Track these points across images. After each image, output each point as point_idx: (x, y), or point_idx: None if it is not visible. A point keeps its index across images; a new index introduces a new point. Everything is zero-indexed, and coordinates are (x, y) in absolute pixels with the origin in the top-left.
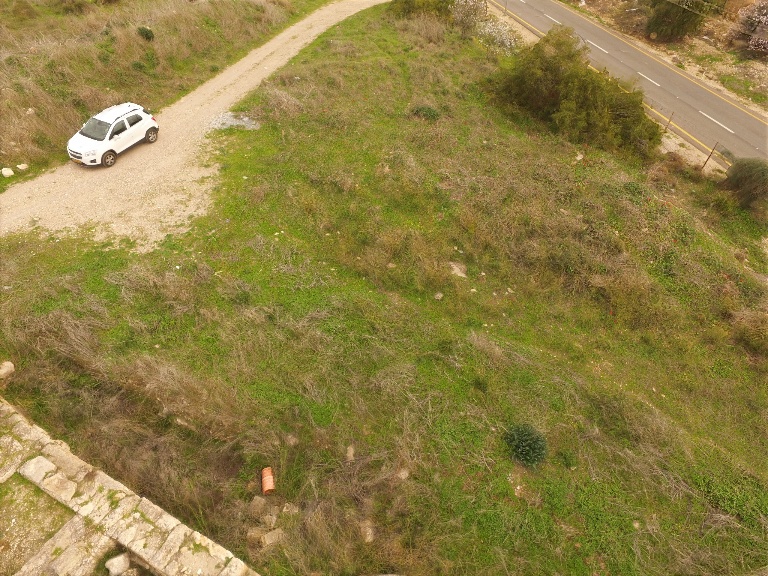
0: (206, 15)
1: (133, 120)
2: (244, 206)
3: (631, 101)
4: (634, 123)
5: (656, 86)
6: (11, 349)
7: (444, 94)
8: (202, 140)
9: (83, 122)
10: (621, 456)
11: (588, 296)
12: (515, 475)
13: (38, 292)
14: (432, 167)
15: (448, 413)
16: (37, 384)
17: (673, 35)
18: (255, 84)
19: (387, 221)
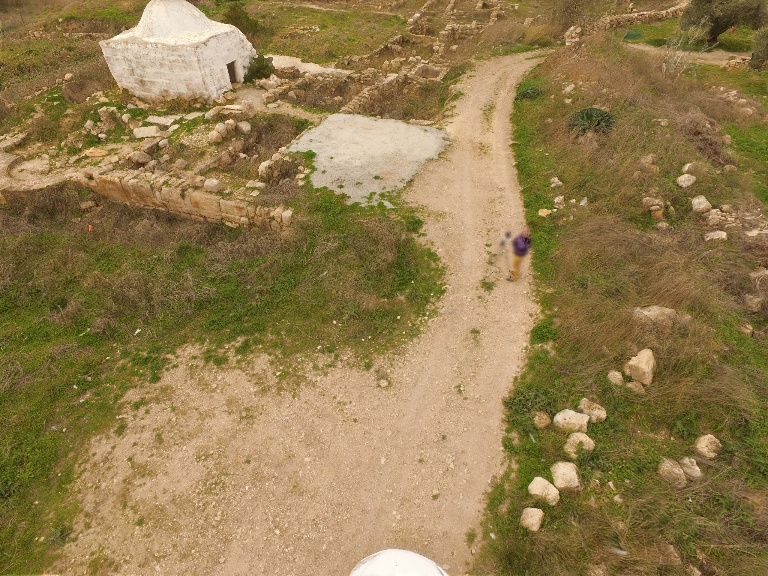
0: None
1: None
2: (6, 459)
3: None
4: None
5: None
6: None
7: None
8: None
9: None
10: None
11: None
12: None
13: None
14: None
15: None
16: None
17: None
18: None
19: None
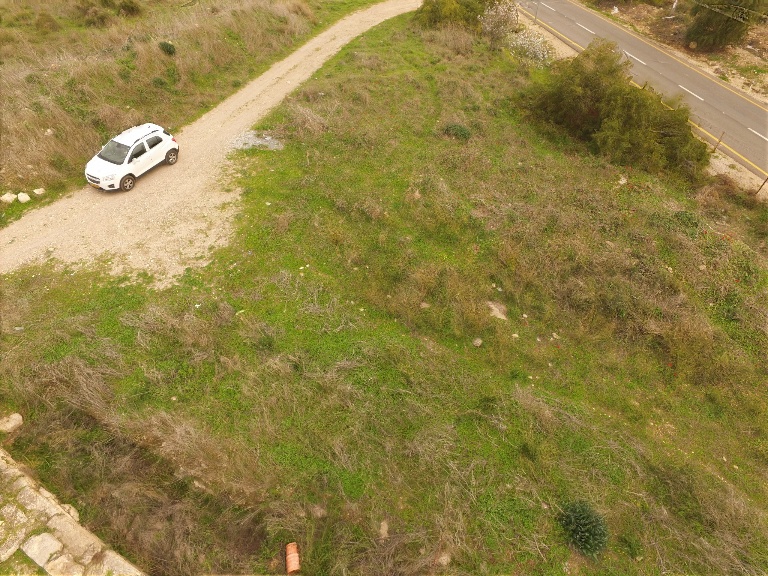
0: (228, 28)
1: (153, 142)
2: (267, 237)
3: (677, 119)
4: (680, 143)
5: (699, 100)
6: (20, 400)
7: (474, 110)
8: (223, 161)
9: (102, 143)
10: (696, 548)
11: (643, 344)
12: (572, 564)
13: (50, 335)
14: (465, 192)
15: (493, 485)
16: (46, 439)
17: (715, 45)
18: (278, 100)
19: (419, 253)
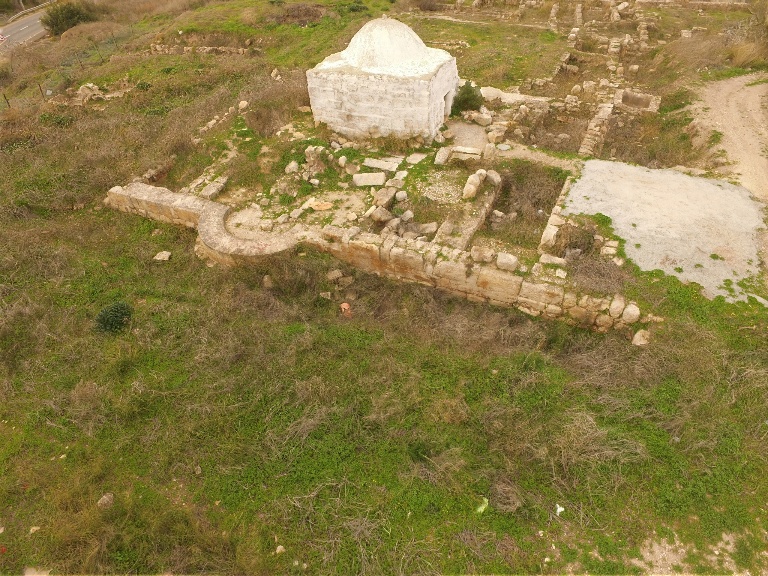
0: None
1: None
2: None
3: None
4: None
5: None
6: None
7: None
8: None
9: None
10: None
11: None
12: None
13: None
14: None
15: None
16: None
17: None
18: None
19: None
